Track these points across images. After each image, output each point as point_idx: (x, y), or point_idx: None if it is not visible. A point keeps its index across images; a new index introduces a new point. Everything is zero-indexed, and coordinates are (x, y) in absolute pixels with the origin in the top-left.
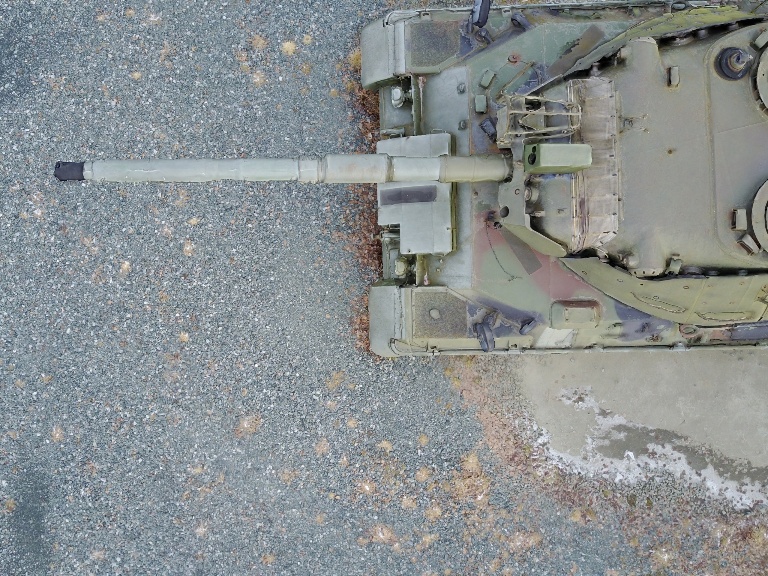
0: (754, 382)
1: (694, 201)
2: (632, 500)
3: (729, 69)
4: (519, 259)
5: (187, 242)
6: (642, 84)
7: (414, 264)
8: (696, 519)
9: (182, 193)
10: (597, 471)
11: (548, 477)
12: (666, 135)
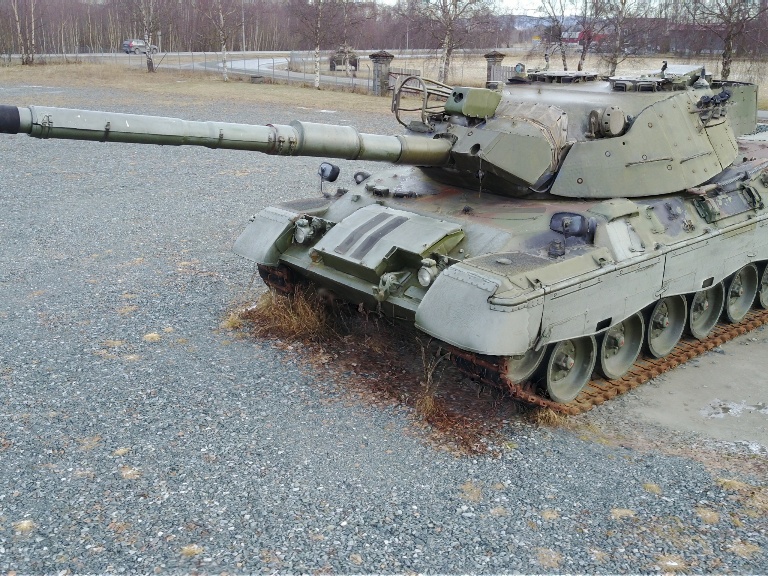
0: None
1: None
2: None
3: (519, 78)
4: (523, 213)
5: (123, 468)
6: None
7: (440, 261)
8: None
9: (85, 440)
10: None
11: None
12: None
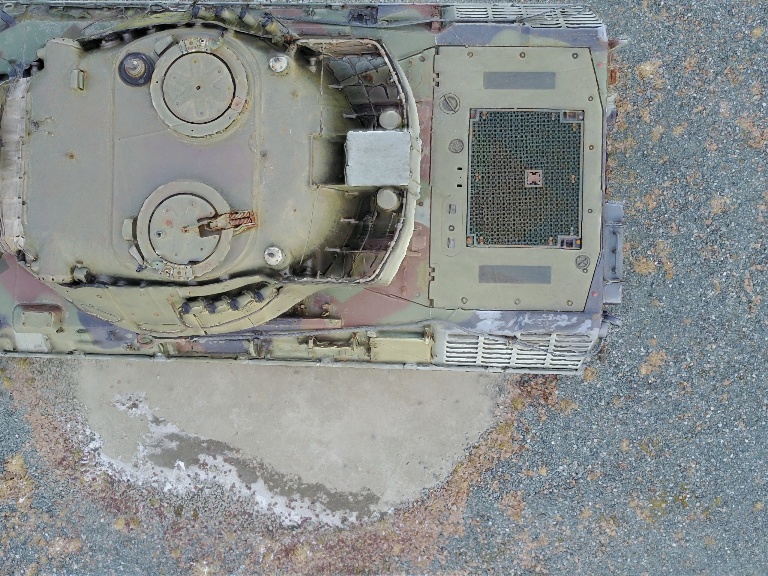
0: (309, 397)
1: (93, 208)
2: (178, 510)
3: (127, 74)
4: None
5: None
6: (50, 86)
7: None
8: (241, 533)
9: None
10: (147, 479)
11: (95, 483)
12: (70, 139)
